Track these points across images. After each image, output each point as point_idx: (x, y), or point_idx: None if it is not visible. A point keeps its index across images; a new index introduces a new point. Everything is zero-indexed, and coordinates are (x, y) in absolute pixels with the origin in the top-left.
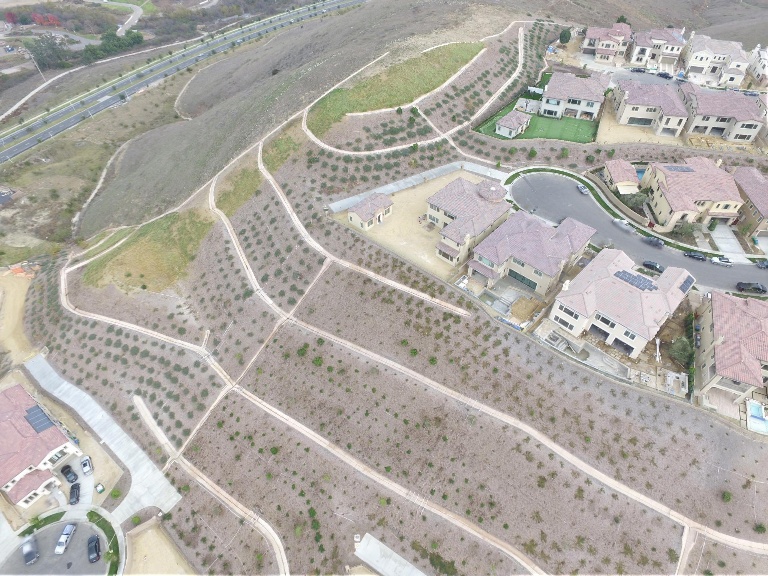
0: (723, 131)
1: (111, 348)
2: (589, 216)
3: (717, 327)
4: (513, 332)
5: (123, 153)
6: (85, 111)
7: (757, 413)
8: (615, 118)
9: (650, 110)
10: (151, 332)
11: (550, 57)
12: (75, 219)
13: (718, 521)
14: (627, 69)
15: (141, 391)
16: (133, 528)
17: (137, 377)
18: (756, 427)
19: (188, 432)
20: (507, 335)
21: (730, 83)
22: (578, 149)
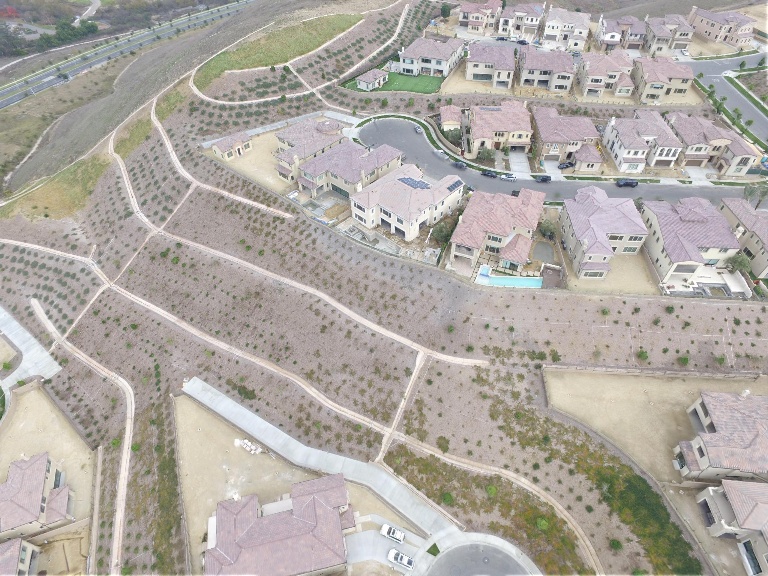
0: (548, 83)
1: (15, 264)
2: (416, 149)
3: (465, 213)
4: (321, 227)
5: (58, 123)
6: (29, 89)
7: (486, 273)
8: (464, 75)
9: (488, 67)
10: (49, 250)
11: (430, 29)
12: (7, 177)
13: (443, 346)
14: (493, 38)
15: (37, 295)
16: (18, 388)
17: (35, 284)
18: (481, 281)
19: (71, 321)
20: (316, 229)
21: (575, 48)
22: (423, 99)
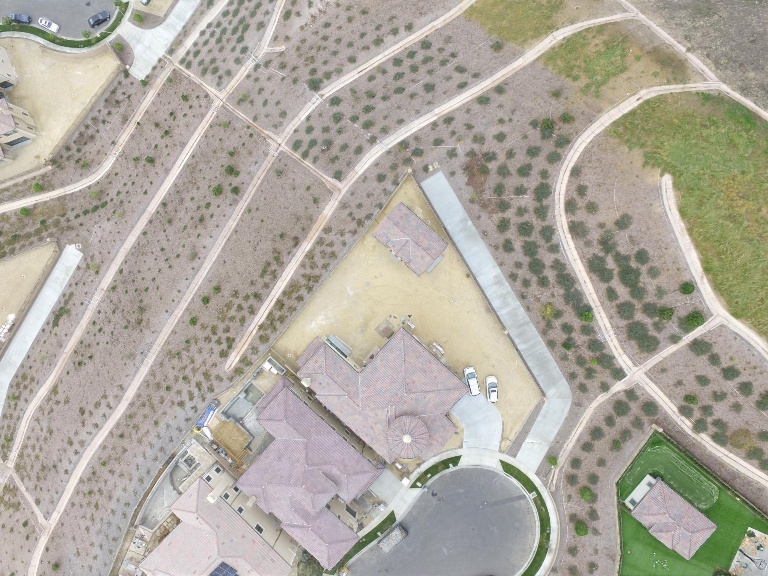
0: None
1: None
2: (418, 572)
3: None
4: (196, 417)
5: None
6: None
7: None
8: None
9: None
10: None
11: None
12: None
13: (48, 550)
14: None
15: None
16: None
17: None
18: None
19: (188, 66)
20: (195, 409)
21: None
22: None
